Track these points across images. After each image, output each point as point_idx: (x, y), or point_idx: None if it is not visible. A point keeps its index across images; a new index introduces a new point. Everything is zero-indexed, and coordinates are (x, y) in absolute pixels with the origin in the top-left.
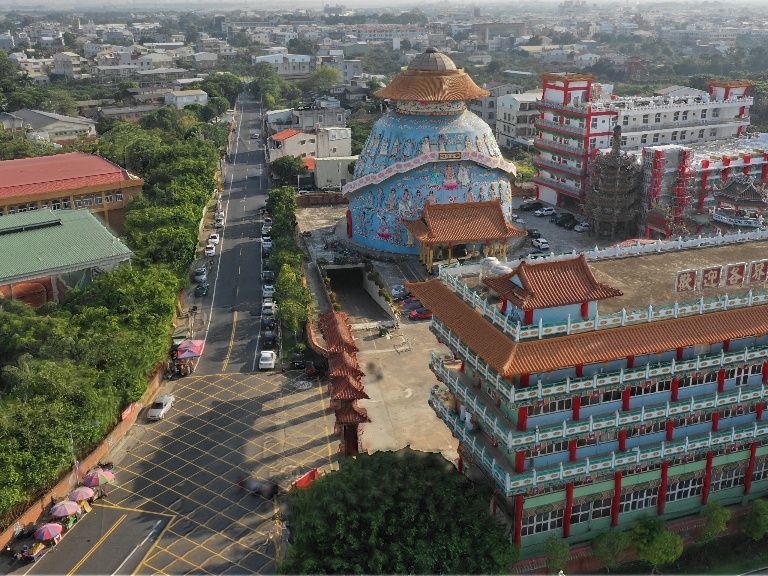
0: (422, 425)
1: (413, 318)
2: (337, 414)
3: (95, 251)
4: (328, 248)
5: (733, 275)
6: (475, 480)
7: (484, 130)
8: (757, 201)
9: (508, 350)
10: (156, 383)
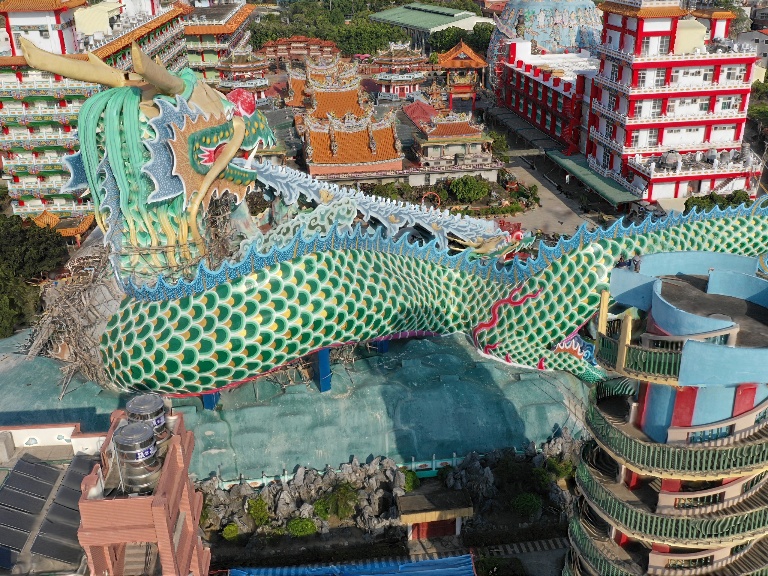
0: None
1: None
2: None
3: (429, 25)
4: None
5: (184, 1)
6: None
7: (524, 6)
8: None
9: None
10: (348, 60)
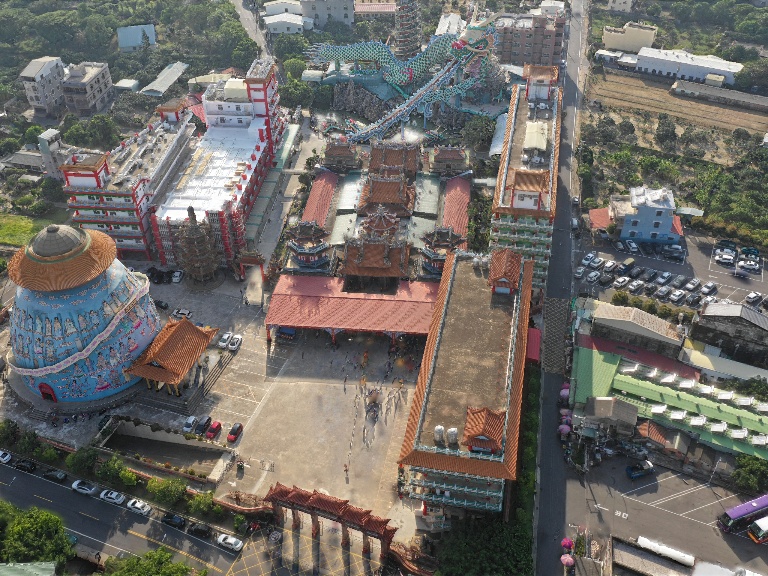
0: (363, 503)
1: (234, 441)
2: (384, 539)
3: None
4: (56, 424)
5: None
6: (456, 513)
7: (122, 266)
8: (323, 234)
9: (503, 468)
10: None
